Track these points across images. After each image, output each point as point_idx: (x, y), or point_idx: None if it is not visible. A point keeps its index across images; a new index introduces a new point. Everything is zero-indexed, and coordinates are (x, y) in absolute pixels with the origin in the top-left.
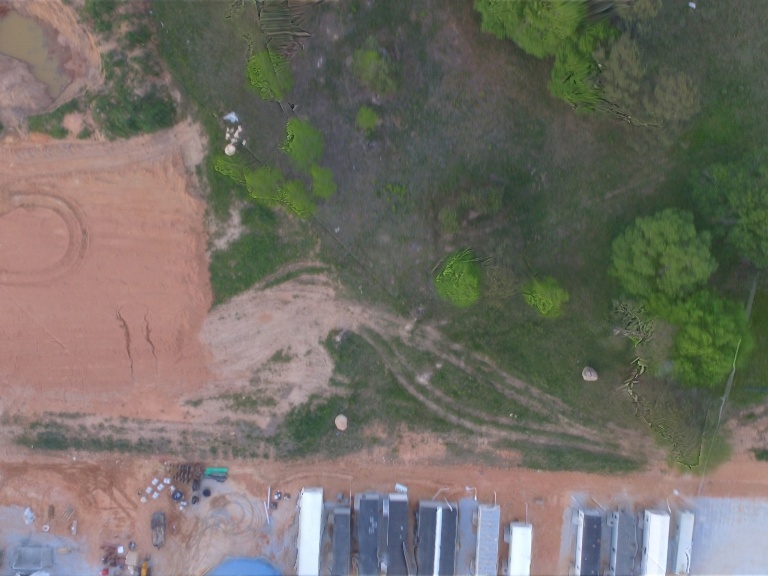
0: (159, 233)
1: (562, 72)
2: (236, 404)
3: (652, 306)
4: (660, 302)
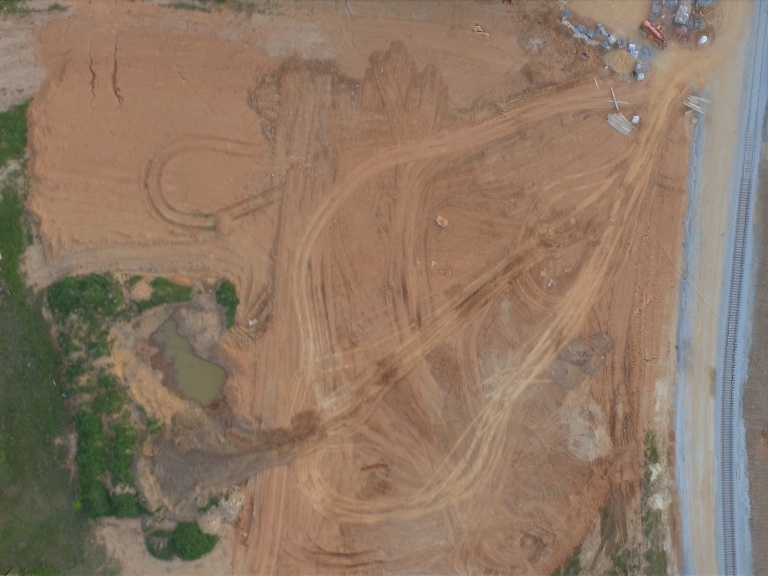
0: (73, 179)
1: None
2: (15, 3)
3: None
4: None
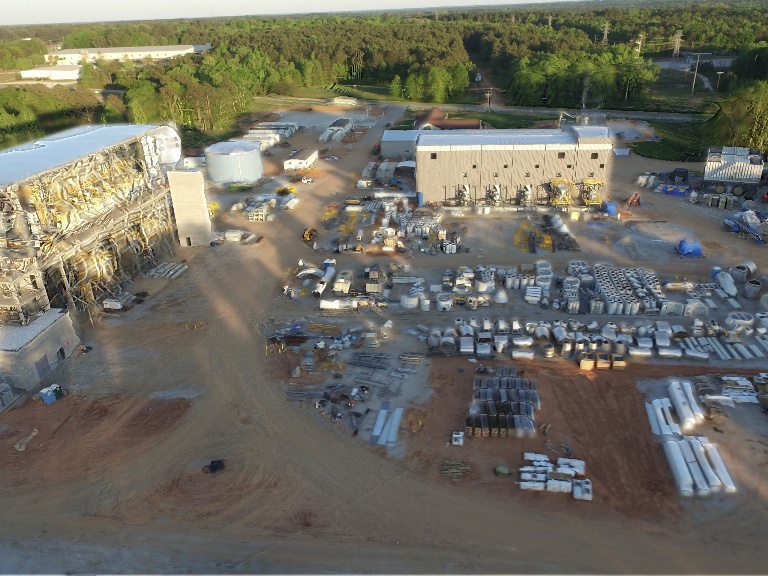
0: None
1: (53, 109)
2: None
3: (161, 102)
4: (160, 99)
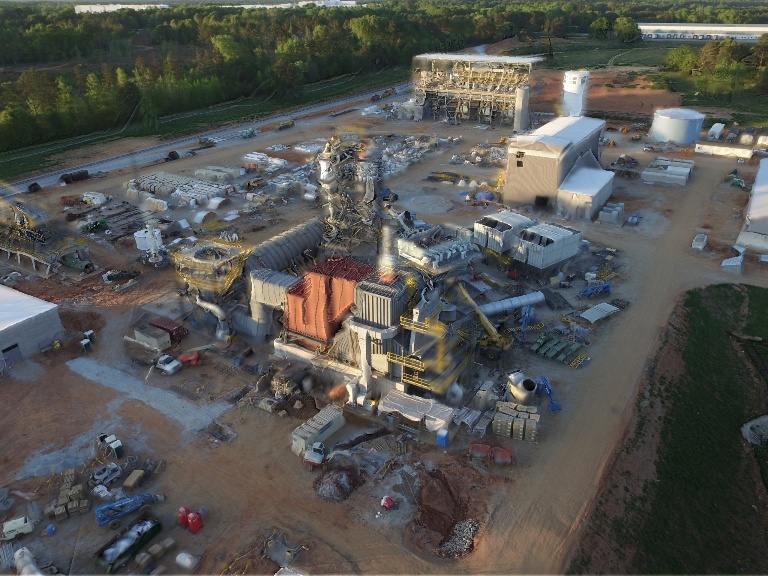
0: None
1: None
2: None
3: None
4: None
